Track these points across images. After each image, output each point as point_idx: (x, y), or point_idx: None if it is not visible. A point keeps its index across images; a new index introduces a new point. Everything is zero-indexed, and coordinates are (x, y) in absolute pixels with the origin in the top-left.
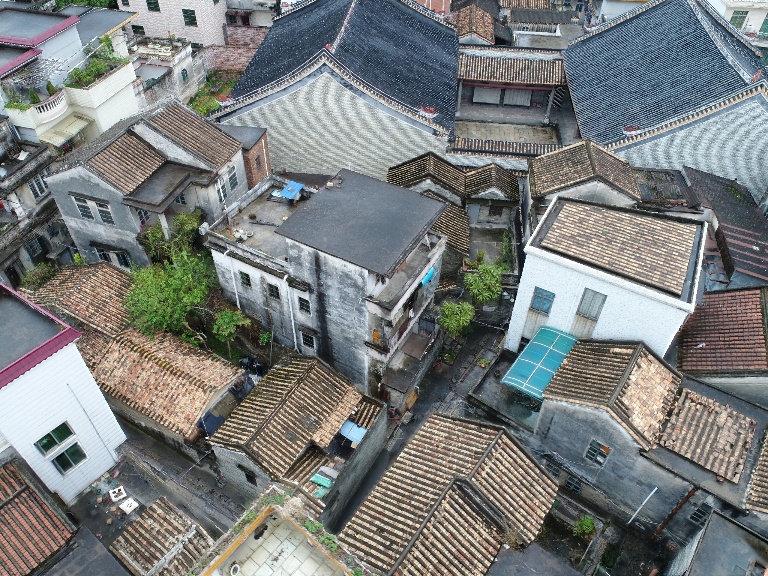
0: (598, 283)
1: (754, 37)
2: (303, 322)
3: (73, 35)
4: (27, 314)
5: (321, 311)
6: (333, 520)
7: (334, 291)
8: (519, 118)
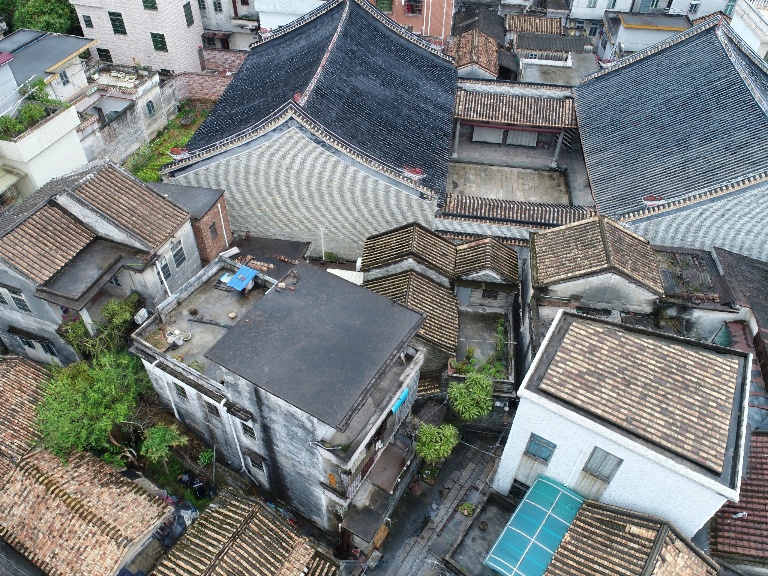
0: (612, 445)
1: None
2: (249, 446)
3: (5, 75)
4: None
5: (268, 441)
6: None
7: (280, 426)
8: (523, 161)
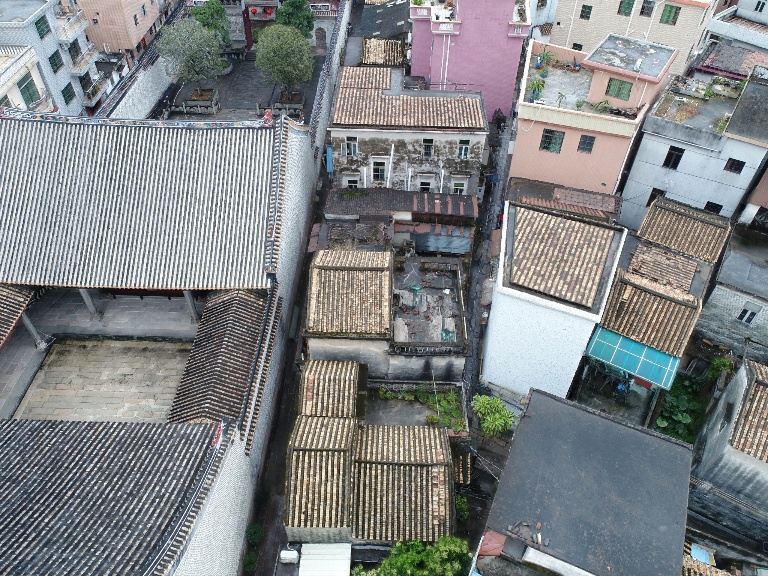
0: None
1: None
2: None
3: None
4: None
5: None
6: None
7: None
8: (18, 378)
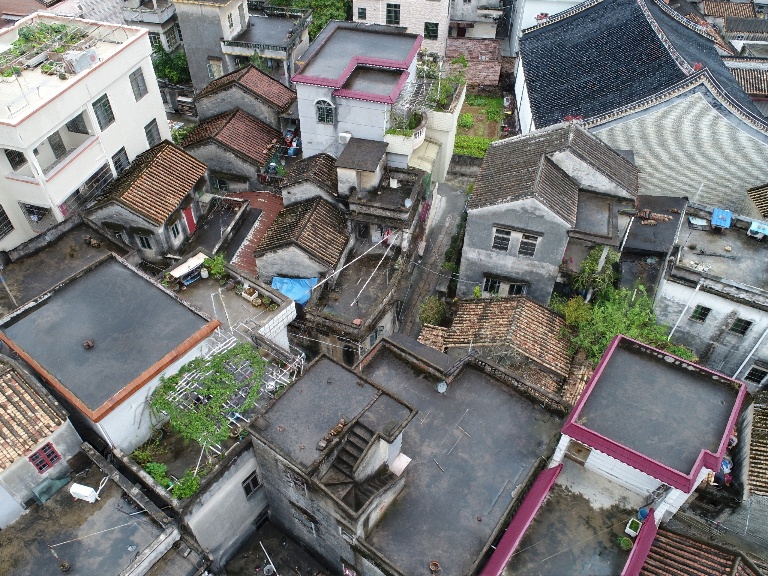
0: None
1: None
2: (765, 357)
3: None
4: (667, 368)
5: None
6: None
7: None
8: None
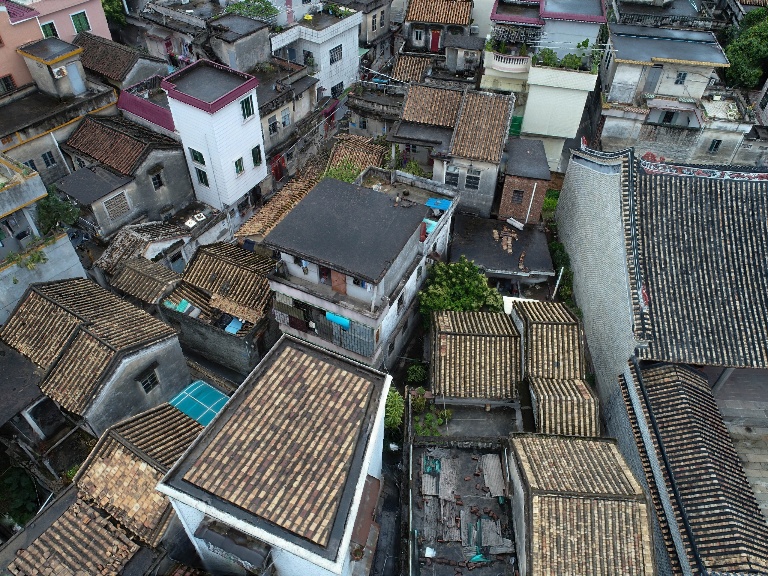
0: None
1: None
2: None
3: (592, 31)
4: None
5: None
6: (179, 341)
7: None
8: None
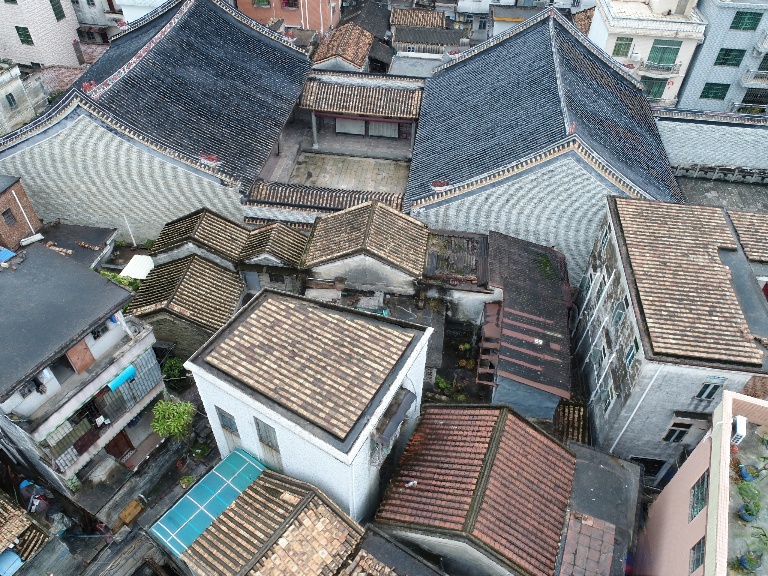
0: (261, 414)
1: (633, 68)
2: None
3: None
4: None
5: None
6: None
7: None
8: (383, 151)
